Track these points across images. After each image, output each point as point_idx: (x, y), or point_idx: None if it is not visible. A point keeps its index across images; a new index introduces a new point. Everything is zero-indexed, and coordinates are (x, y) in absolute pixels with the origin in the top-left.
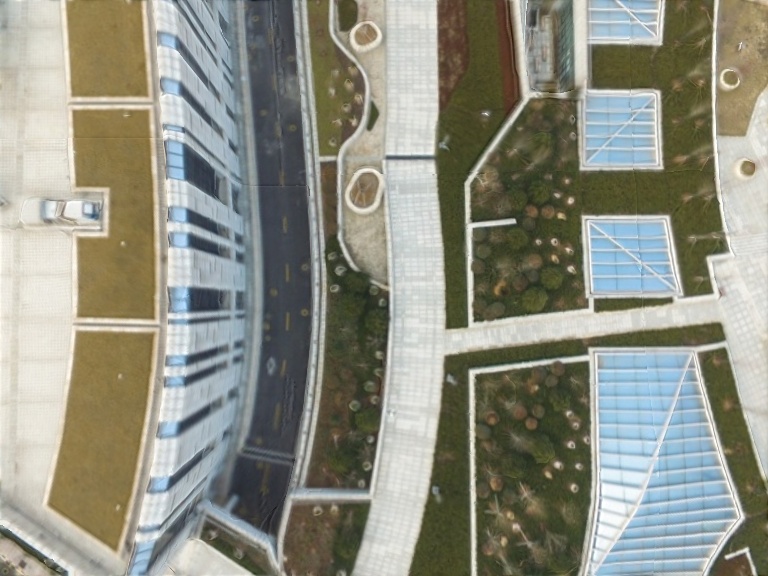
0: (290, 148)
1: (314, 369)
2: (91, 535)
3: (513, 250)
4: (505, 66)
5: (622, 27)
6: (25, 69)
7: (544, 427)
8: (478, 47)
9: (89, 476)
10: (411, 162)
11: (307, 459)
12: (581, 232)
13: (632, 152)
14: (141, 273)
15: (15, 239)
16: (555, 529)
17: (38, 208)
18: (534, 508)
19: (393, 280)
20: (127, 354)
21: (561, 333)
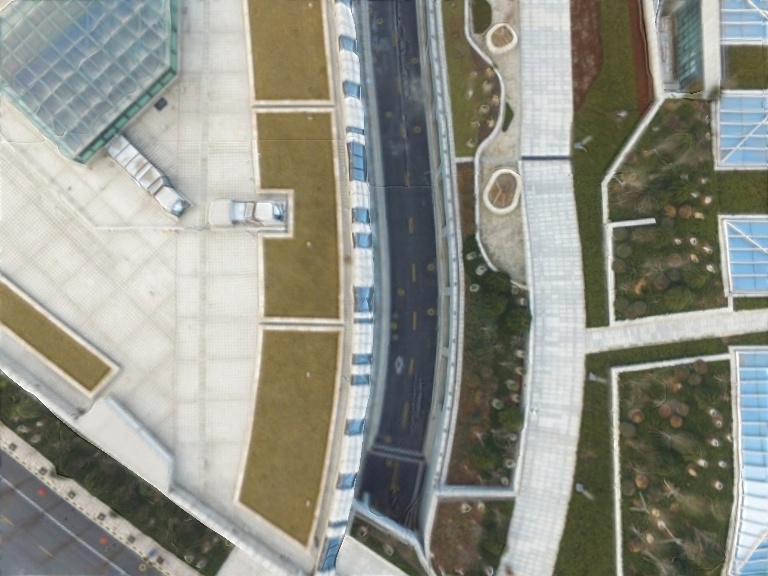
0: (415, 149)
1: (453, 368)
2: (281, 531)
3: (654, 249)
4: (639, 67)
5: (754, 28)
6: (208, 73)
7: (688, 425)
8: (612, 48)
9: (278, 473)
10: (546, 163)
11: (447, 457)
12: (717, 231)
13: (766, 152)
14: (325, 273)
15: (201, 240)
16: (704, 526)
17: (227, 209)
18: (678, 505)
19: (533, 279)
20: (313, 353)
21: (700, 332)
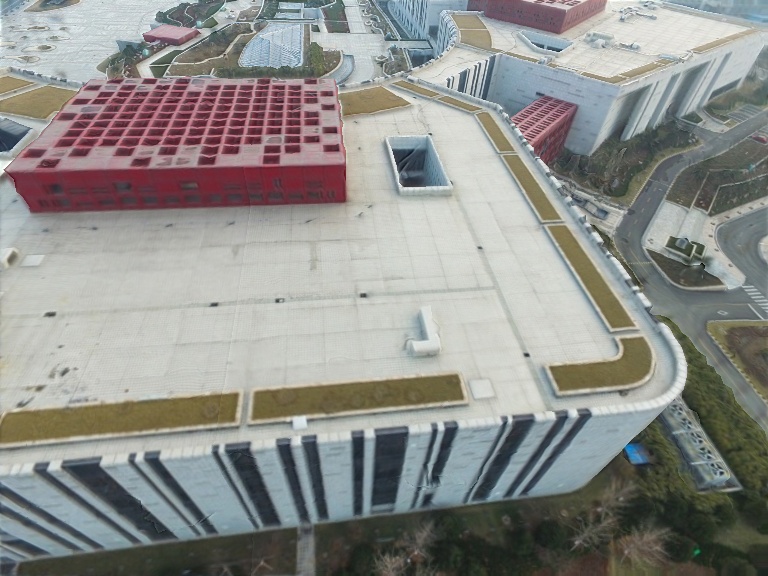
0: None
1: None
2: None
3: None
4: None
5: None
6: None
7: None
8: None
9: None
10: (351, 6)
11: None
12: None
13: None
14: None
15: None
16: None
17: None
18: None
19: None
20: None
21: None
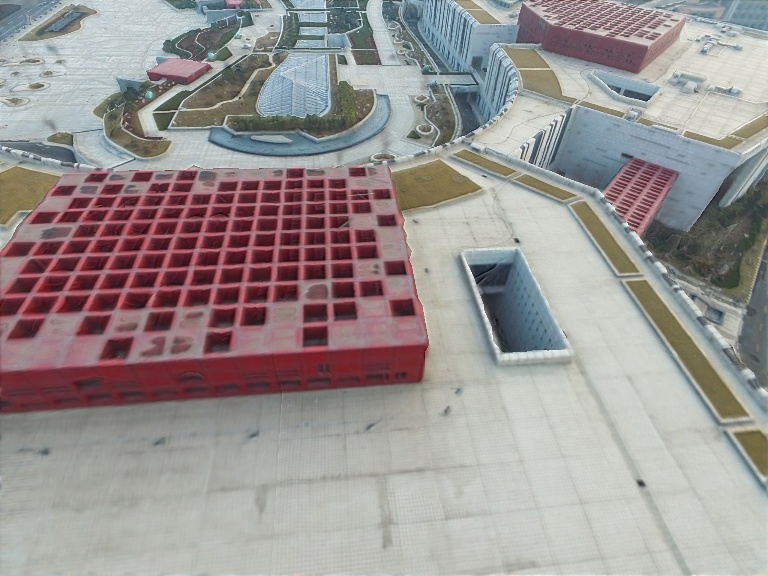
0: None
1: None
2: None
3: None
4: None
5: None
6: None
7: None
8: None
9: None
10: None
11: None
12: None
13: None
14: None
15: None
16: None
17: None
18: None
19: None
20: None
21: None
